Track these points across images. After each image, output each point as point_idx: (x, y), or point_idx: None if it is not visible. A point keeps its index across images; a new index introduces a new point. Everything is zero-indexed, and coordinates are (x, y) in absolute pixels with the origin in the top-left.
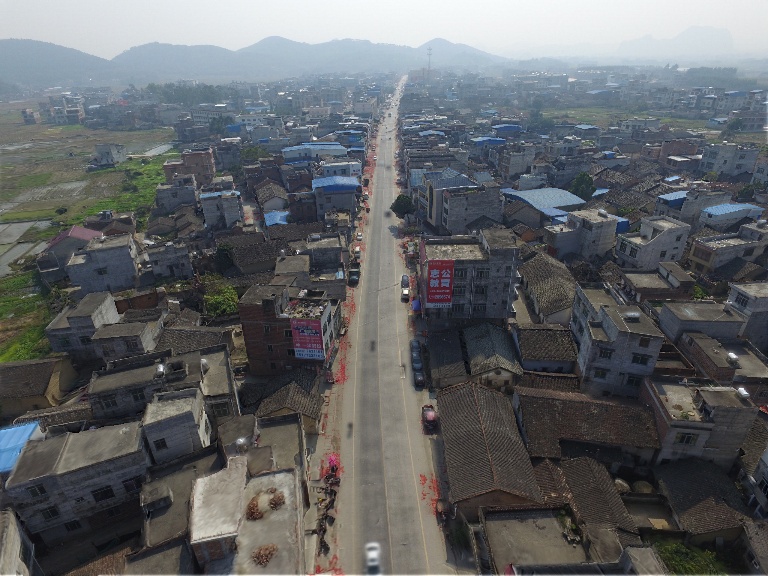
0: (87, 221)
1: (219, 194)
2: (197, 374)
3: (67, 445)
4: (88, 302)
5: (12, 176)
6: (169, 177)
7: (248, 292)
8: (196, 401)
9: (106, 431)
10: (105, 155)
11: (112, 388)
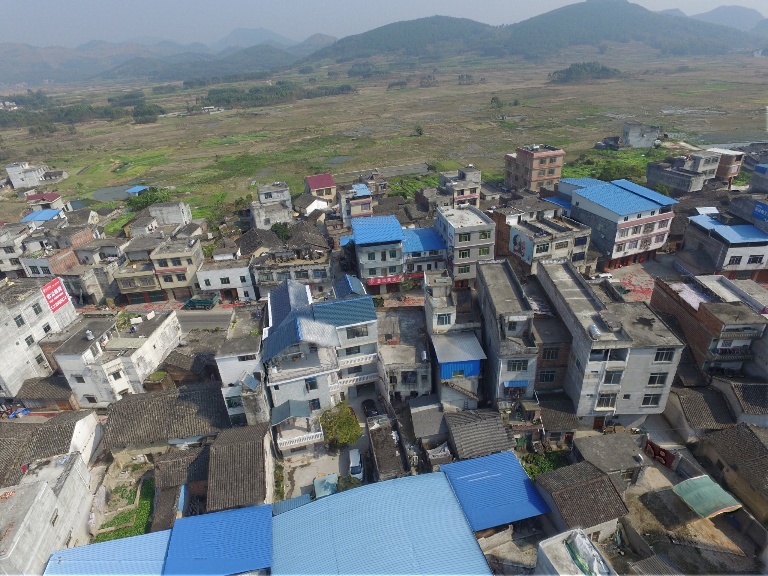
0: (363, 176)
1: (356, 188)
2: (29, 239)
3: (18, 227)
4: (168, 203)
5: (564, 136)
6: (506, 169)
7: (78, 227)
8: (5, 243)
9: (15, 231)
10: (625, 135)
11: (46, 224)
